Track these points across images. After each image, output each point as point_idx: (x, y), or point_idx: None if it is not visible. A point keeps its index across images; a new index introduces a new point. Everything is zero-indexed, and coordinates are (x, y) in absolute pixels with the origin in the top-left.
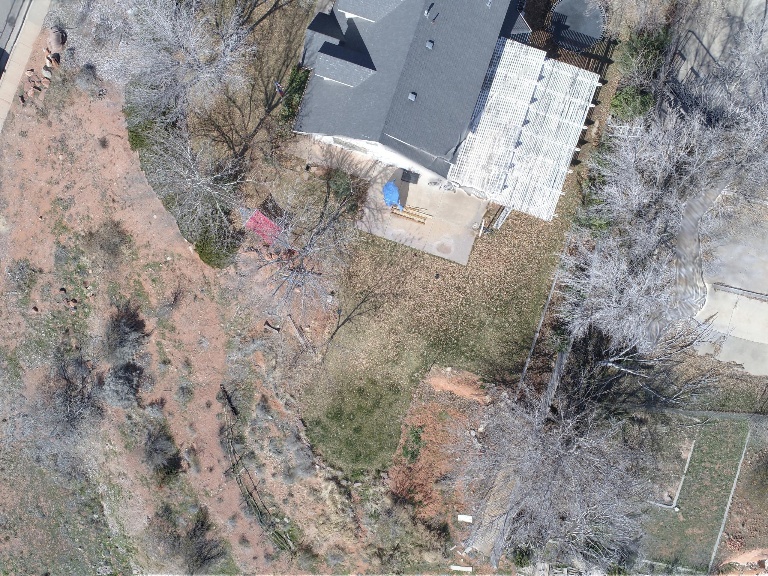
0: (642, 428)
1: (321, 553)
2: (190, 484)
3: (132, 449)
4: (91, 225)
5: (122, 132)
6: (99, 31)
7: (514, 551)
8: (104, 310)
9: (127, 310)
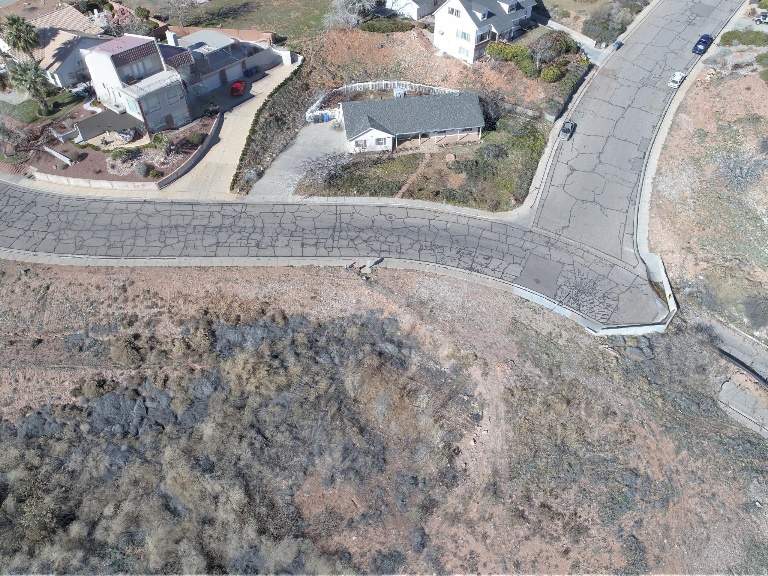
0: None
1: None
2: None
3: None
4: None
5: (760, 83)
6: (735, 66)
7: None
8: (754, 139)
9: (767, 138)
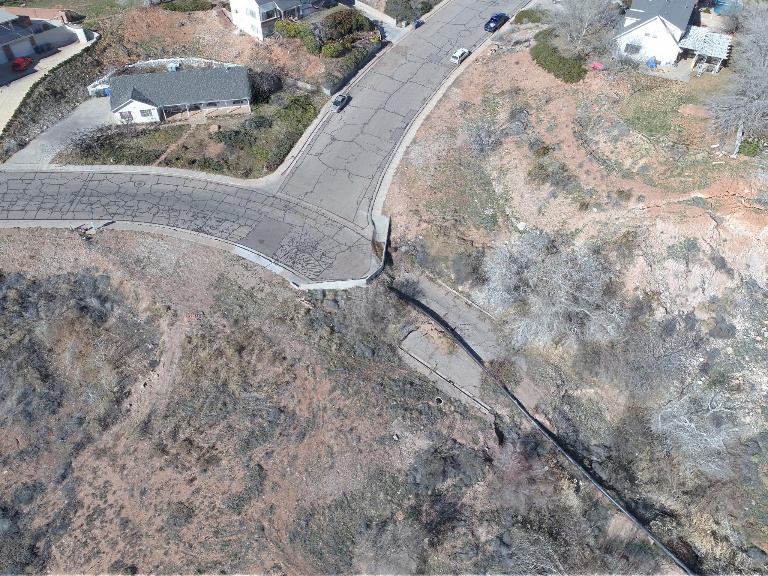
0: None
1: (634, 172)
2: (554, 156)
3: None
4: (503, 89)
5: (528, 57)
6: None
7: (747, 142)
8: None
9: None
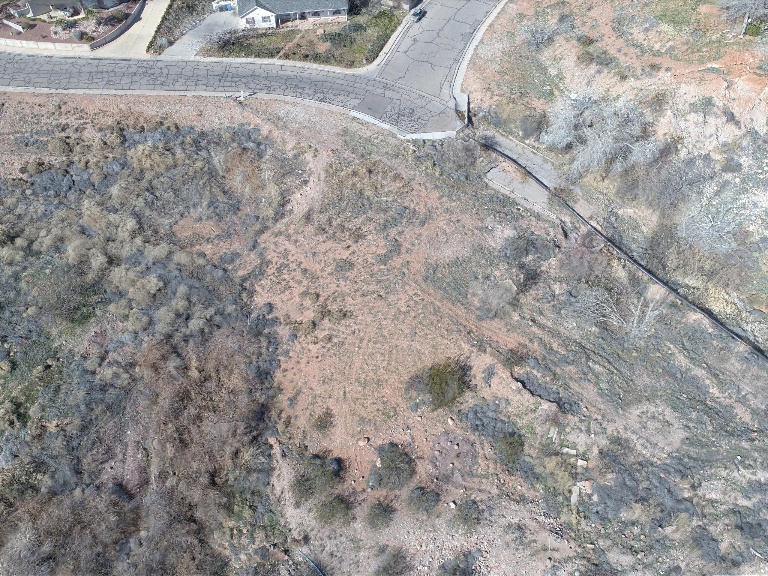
0: None
1: None
2: None
3: (570, 41)
4: (551, 3)
5: None
6: None
7: None
8: None
9: None
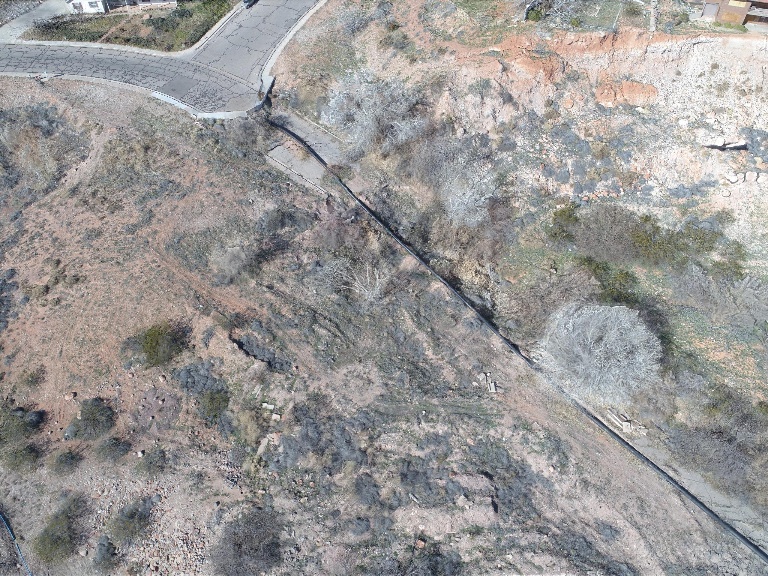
0: (580, 3)
1: (454, 36)
2: None
3: None
4: None
5: None
6: None
7: None
8: None
9: None
